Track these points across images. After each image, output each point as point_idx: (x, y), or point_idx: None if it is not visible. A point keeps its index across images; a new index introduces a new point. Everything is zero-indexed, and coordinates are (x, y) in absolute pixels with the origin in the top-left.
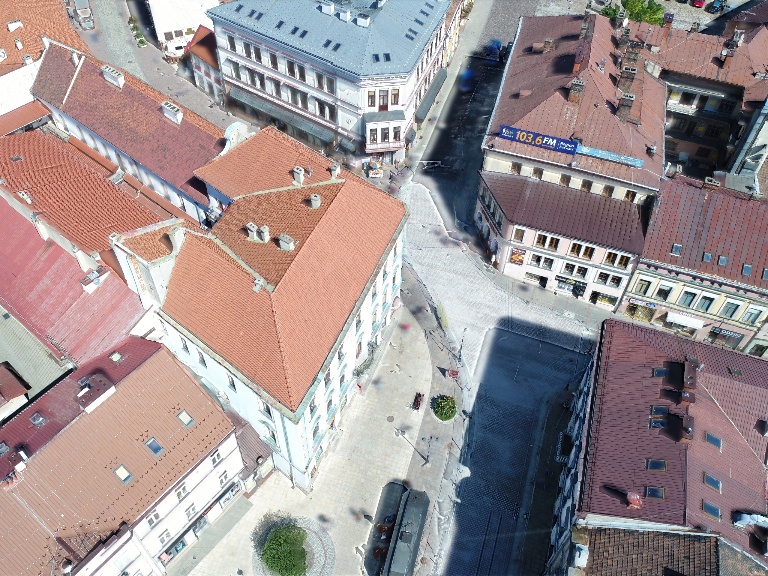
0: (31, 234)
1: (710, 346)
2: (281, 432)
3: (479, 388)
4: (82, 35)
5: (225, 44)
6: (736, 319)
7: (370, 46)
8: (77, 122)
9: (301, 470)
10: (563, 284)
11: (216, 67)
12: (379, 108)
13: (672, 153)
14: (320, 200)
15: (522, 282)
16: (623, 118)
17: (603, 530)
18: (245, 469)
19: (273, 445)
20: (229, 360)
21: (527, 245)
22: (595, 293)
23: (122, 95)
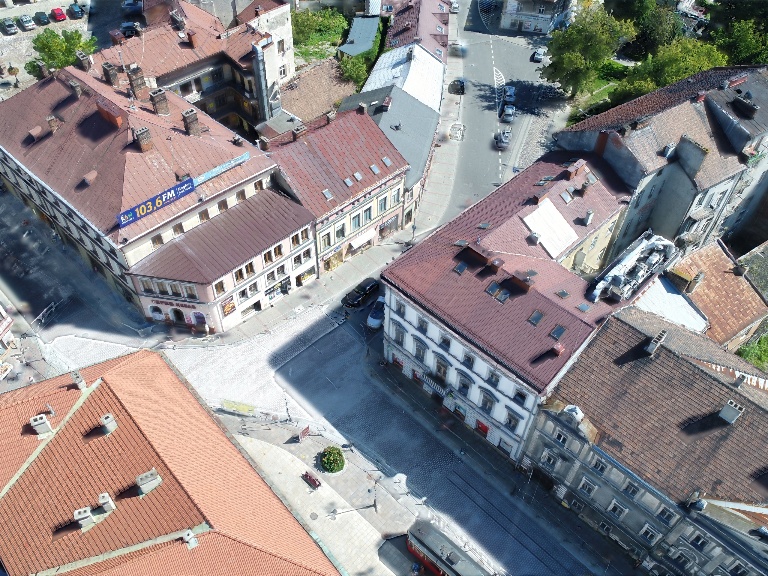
0: None
1: (445, 228)
2: None
3: (328, 421)
4: None
5: None
6: (389, 208)
7: None
8: None
9: None
10: (272, 294)
11: None
12: None
13: None
14: None
15: (243, 323)
16: (197, 133)
17: (559, 387)
18: None
19: None
20: None
21: (230, 290)
22: (297, 278)
23: None
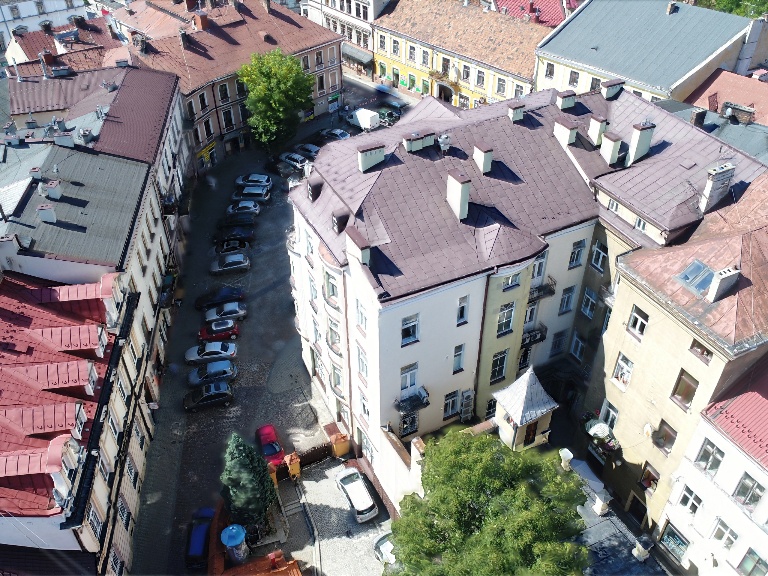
0: None
1: None
2: None
3: None
4: None
5: None
6: None
7: None
8: None
9: None
10: None
11: None
12: None
13: None
14: None
15: None
16: None
17: None
18: None
19: None
20: None
21: None
22: None
23: None
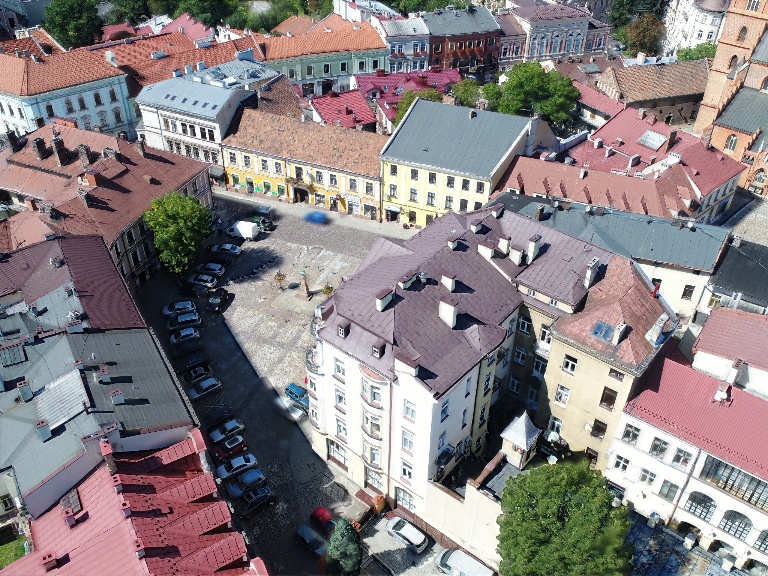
0: None
1: None
2: None
3: None
4: None
5: None
6: None
7: None
8: None
9: None
10: None
11: None
12: None
13: None
14: None
15: None
16: None
17: None
18: None
19: None
20: None
21: None
22: None
23: None
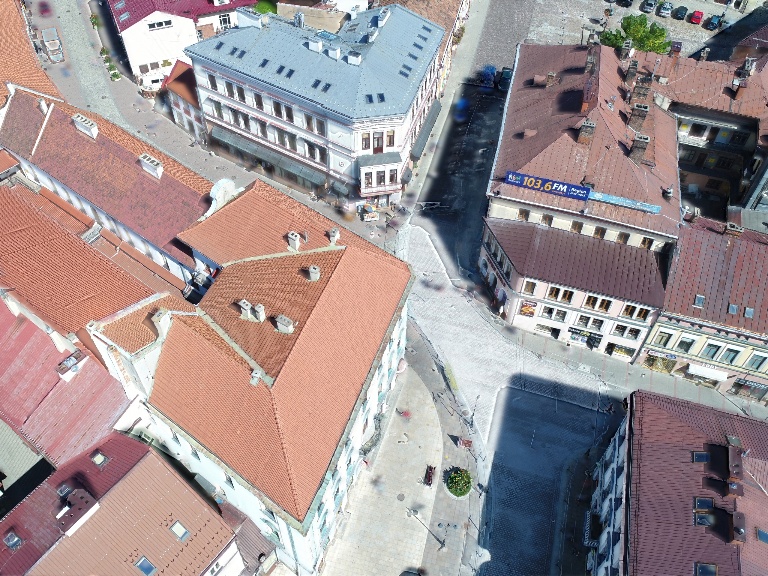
0: (0, 309)
1: (749, 419)
2: (286, 534)
3: (494, 457)
4: (51, 69)
5: (205, 83)
6: (763, 371)
7: (362, 86)
8: (48, 175)
9: (308, 570)
10: (576, 335)
11: (196, 105)
12: (373, 150)
13: (681, 185)
14: (319, 271)
15: (533, 334)
16: (637, 160)
17: None
18: (246, 570)
19: (276, 541)
20: (226, 461)
21: (538, 297)
22: (611, 344)
23: (96, 146)
